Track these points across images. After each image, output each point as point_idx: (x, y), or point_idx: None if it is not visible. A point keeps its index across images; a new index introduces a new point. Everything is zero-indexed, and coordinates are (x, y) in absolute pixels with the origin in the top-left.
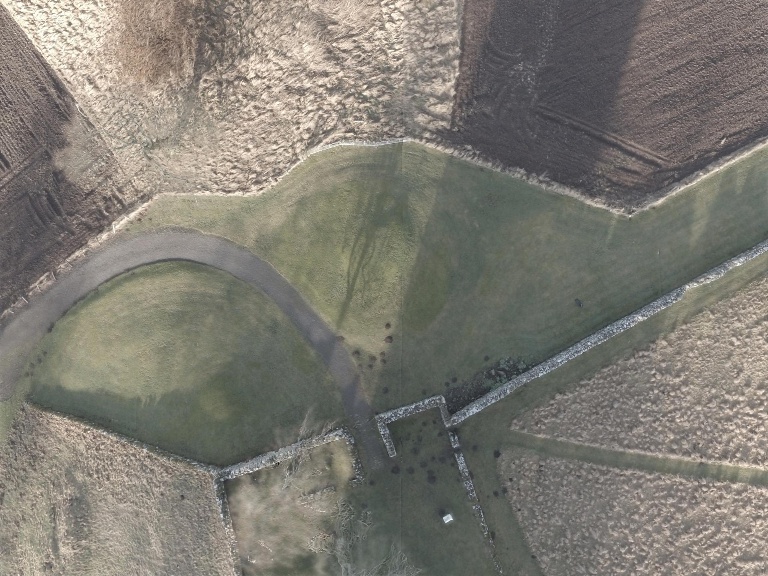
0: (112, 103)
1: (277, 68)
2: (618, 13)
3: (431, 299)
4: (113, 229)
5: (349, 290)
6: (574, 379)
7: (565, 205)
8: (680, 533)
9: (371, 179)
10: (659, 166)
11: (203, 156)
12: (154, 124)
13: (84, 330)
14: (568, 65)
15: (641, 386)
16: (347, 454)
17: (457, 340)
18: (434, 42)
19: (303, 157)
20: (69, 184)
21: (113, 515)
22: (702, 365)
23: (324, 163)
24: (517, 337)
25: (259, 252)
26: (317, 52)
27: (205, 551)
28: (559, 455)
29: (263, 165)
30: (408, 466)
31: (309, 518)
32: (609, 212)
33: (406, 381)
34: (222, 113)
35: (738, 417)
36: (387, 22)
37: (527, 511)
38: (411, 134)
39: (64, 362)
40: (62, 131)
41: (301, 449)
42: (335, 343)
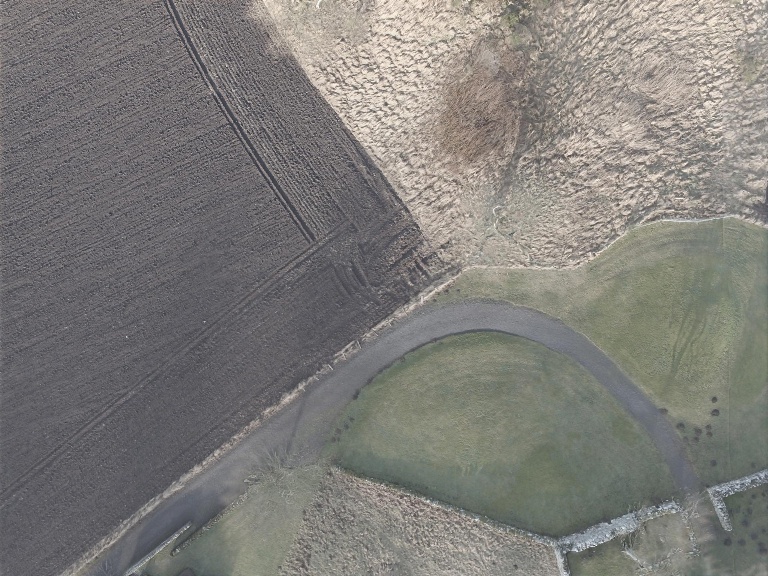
0: (424, 179)
1: (595, 146)
2: None
3: (758, 373)
4: (421, 300)
5: (674, 364)
6: None
7: None
8: None
9: (695, 255)
10: None
11: (518, 231)
12: (467, 200)
13: (394, 398)
14: None
15: None
16: (683, 527)
17: None
18: (751, 119)
19: (624, 233)
20: (374, 256)
21: None
22: None
23: (644, 239)
24: None
25: (573, 324)
26: (638, 131)
27: None
28: None
29: (580, 240)
30: (740, 538)
31: None
32: None
33: (734, 454)
34: (539, 190)
35: None
36: (707, 101)
37: None
38: (731, 210)
39: (375, 429)
40: (370, 205)
41: (638, 522)
42: (658, 415)
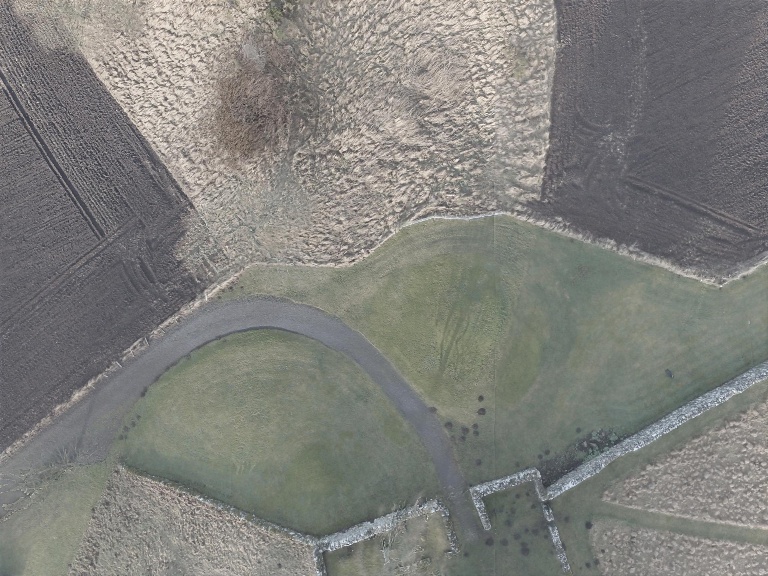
0: (206, 175)
1: (369, 142)
2: (707, 81)
3: (524, 372)
4: (205, 297)
5: (442, 362)
6: (665, 450)
7: (655, 275)
8: None
9: (464, 252)
10: (749, 235)
11: (295, 228)
12: (247, 196)
13: (178, 396)
14: (657, 135)
15: (732, 456)
16: (443, 526)
17: (550, 412)
18: (525, 115)
19: (396, 230)
20: (162, 252)
21: None
22: None
23: (416, 236)
24: (608, 408)
25: (350, 322)
26: (410, 127)
27: None
28: (650, 526)
29: (355, 237)
30: (502, 538)
31: None
32: (699, 282)
33: (499, 453)
34: (315, 186)
35: None
36: (479, 96)
37: None
38: (502, 207)
39: (158, 427)
40: (156, 201)
41: (397, 521)
42: (427, 414)
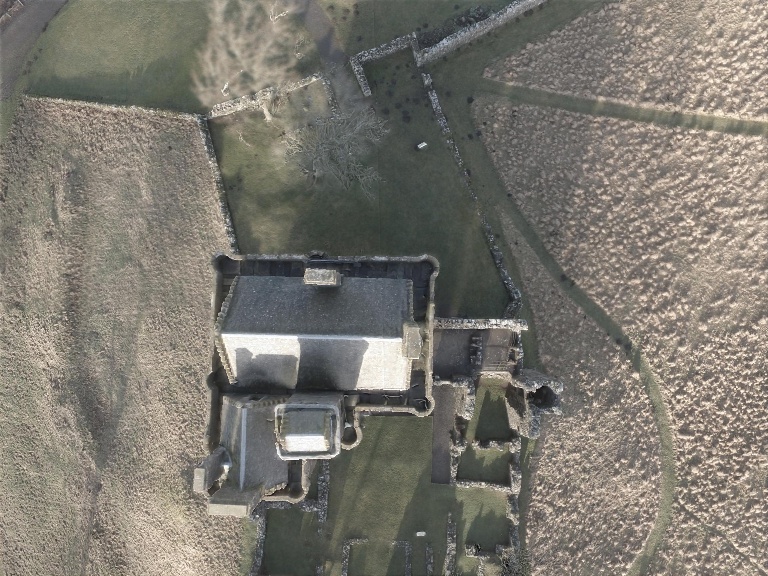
0: None
1: None
2: None
3: None
4: None
5: None
6: (544, 31)
7: None
8: (656, 178)
9: None
10: None
11: None
12: None
13: (75, 21)
14: None
15: (612, 38)
16: (324, 93)
17: None
18: None
19: None
20: None
21: (107, 182)
22: (673, 17)
23: None
24: None
25: None
26: None
27: (192, 191)
28: (532, 102)
29: None
30: (383, 107)
31: (289, 156)
32: None
33: (379, 28)
34: None
35: (711, 67)
36: None
37: (502, 152)
38: None
39: (58, 53)
40: None
41: (279, 90)
42: (310, 2)
